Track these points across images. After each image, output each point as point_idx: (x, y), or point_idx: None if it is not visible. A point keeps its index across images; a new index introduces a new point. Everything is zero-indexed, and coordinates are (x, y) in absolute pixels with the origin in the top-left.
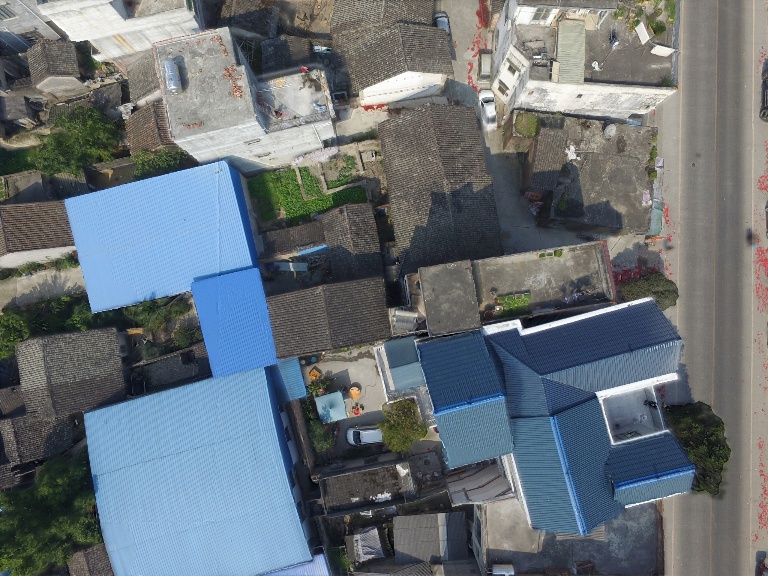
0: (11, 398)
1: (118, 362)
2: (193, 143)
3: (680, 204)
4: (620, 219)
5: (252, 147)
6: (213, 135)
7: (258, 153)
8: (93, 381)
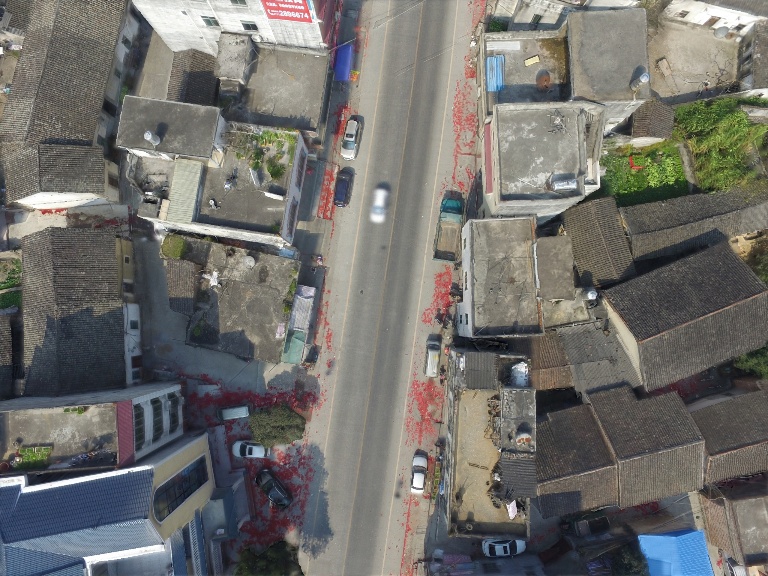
0: None
1: None
2: None
3: (343, 330)
4: (252, 350)
5: None
6: None
7: None
8: None
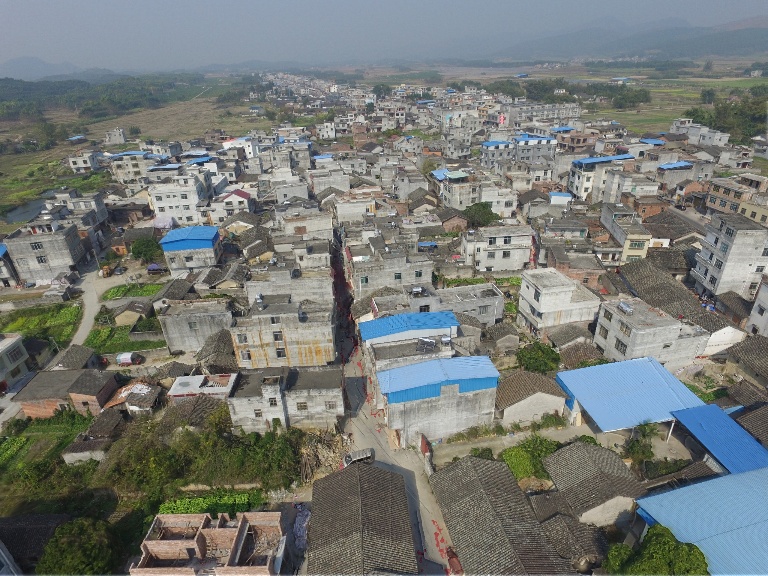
0: (544, 505)
1: (632, 474)
2: (644, 337)
3: None
4: None
5: (662, 352)
6: (657, 332)
7: (660, 360)
8: (626, 480)
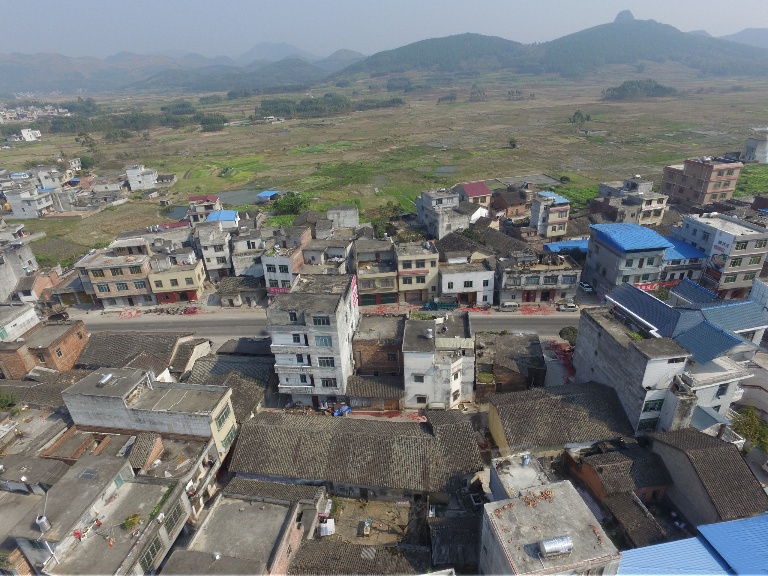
0: None
1: None
2: None
3: None
4: (535, 344)
5: None
6: None
7: None
8: None
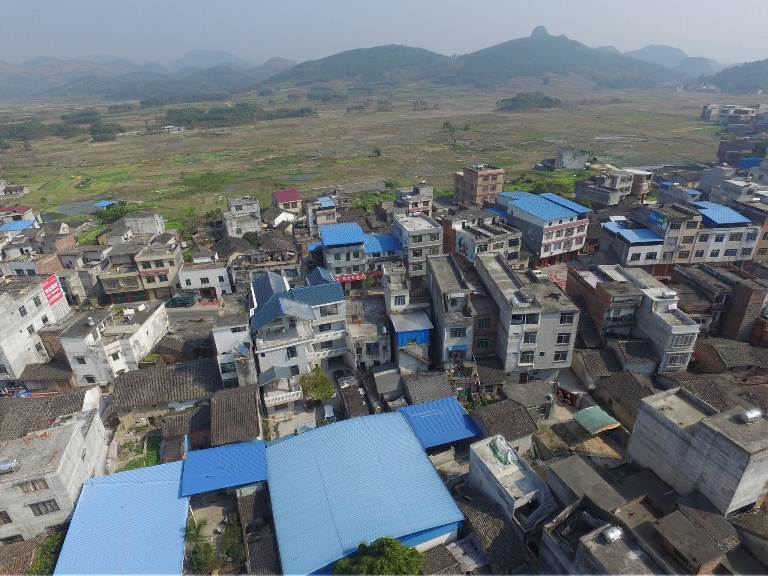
0: None
1: None
2: (64, 471)
3: None
4: None
5: (85, 466)
6: (68, 453)
7: (90, 474)
8: None
